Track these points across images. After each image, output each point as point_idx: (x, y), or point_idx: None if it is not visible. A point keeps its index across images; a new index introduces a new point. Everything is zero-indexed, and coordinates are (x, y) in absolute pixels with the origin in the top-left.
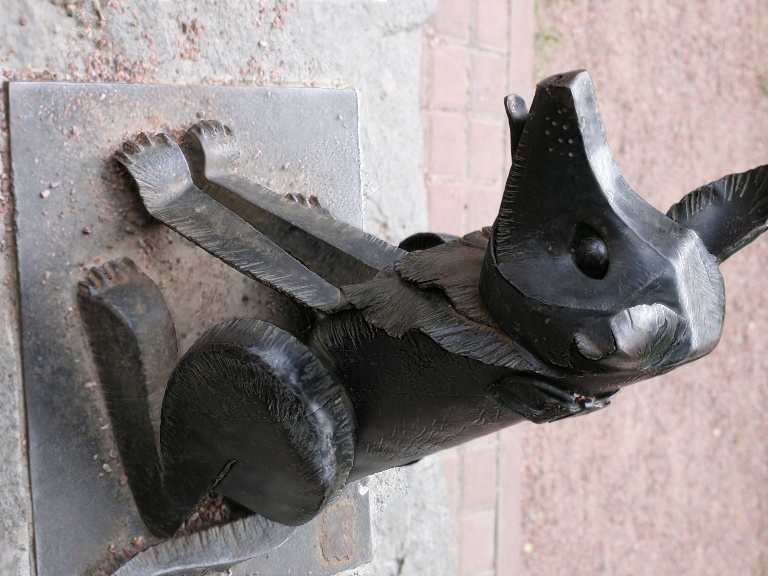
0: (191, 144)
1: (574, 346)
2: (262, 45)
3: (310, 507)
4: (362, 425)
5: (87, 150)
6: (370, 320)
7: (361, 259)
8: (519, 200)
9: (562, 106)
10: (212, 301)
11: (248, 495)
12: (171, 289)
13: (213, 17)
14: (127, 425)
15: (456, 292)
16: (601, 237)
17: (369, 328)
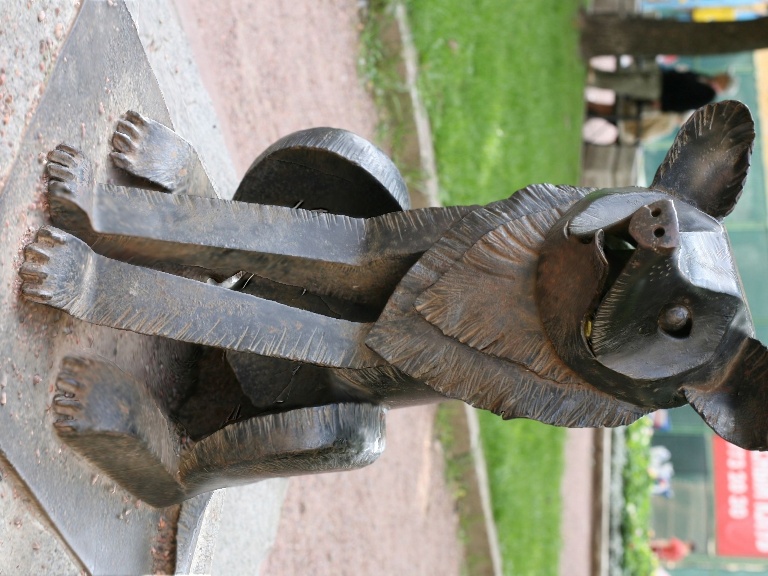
0: (63, 208)
1: (678, 395)
2: (42, 19)
3: None
4: None
5: (2, 317)
6: (436, 388)
7: (319, 257)
8: (616, 314)
9: None
10: None
11: None
12: (94, 332)
13: (3, 48)
14: (138, 480)
15: (534, 361)
16: (683, 305)
17: None
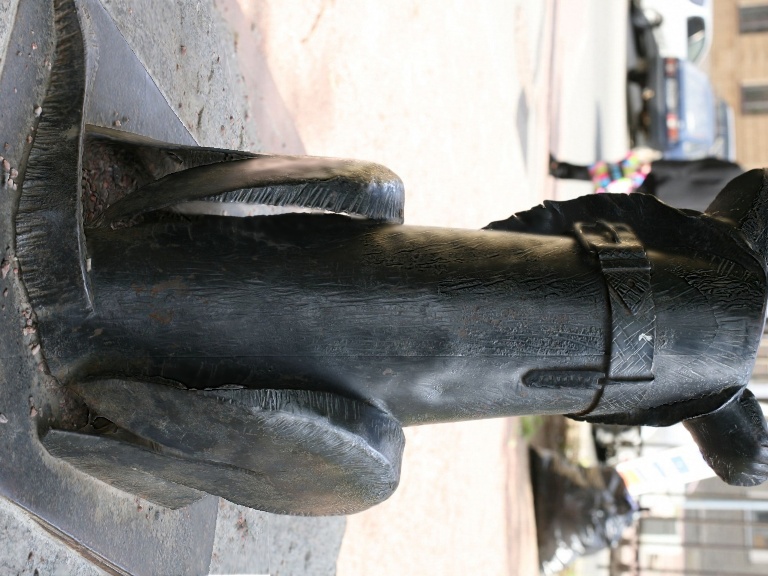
0: None
1: None
2: None
3: None
4: None
5: None
6: None
7: None
8: None
9: None
10: None
11: (225, 169)
12: None
13: None
14: None
15: None
16: None
17: None
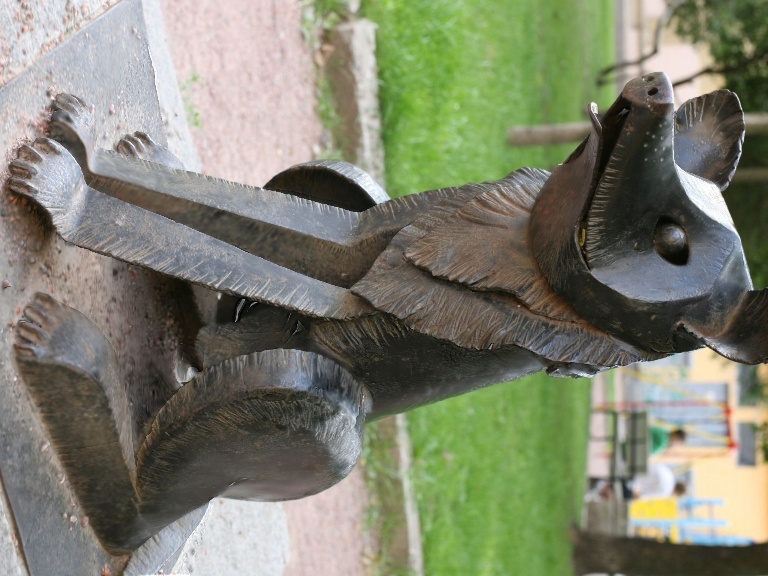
0: (63, 136)
1: (676, 333)
2: None
3: (316, 491)
4: (375, 408)
5: None
6: (422, 330)
7: (310, 233)
8: (611, 209)
9: (664, 120)
10: (96, 292)
11: (236, 495)
12: (70, 301)
13: None
14: (91, 471)
15: (526, 293)
16: (679, 224)
17: (397, 327)
